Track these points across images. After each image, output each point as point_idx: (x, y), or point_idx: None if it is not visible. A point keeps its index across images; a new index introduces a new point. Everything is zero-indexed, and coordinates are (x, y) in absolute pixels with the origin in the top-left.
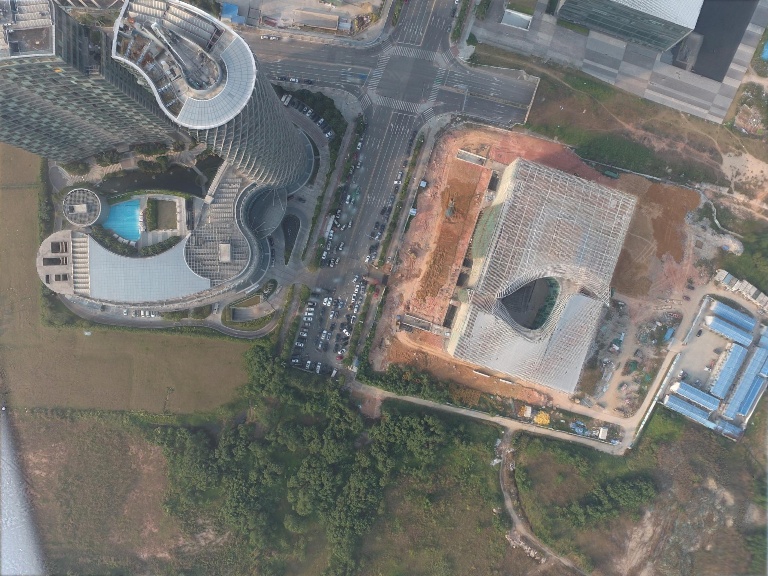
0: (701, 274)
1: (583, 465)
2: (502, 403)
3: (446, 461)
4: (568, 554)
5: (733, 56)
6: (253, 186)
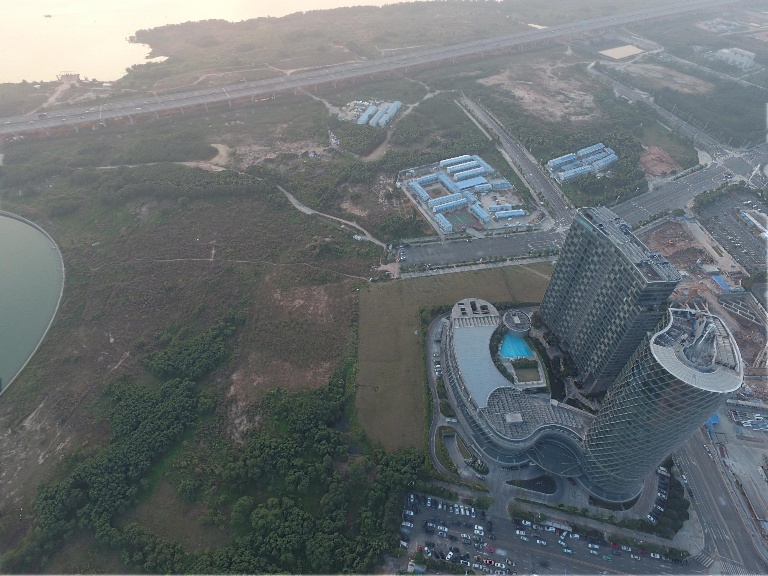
0: None
1: None
2: None
3: None
4: None
5: None
6: (579, 439)
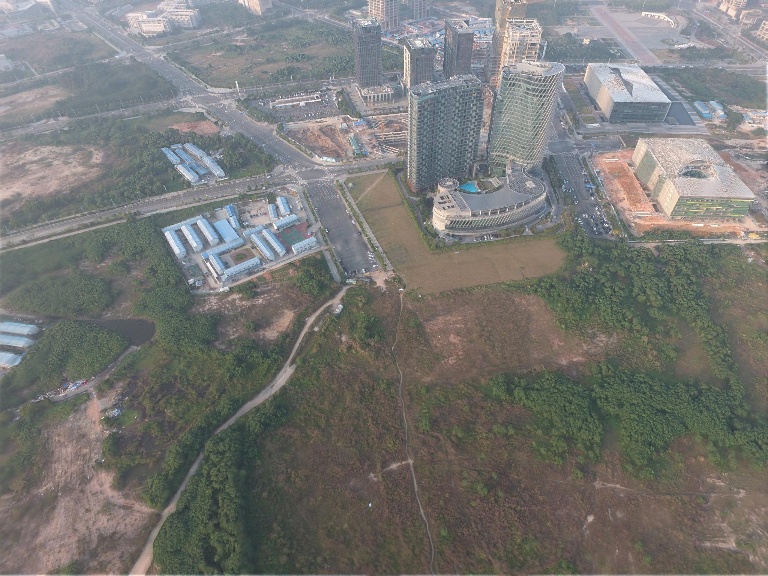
0: (763, 173)
1: None
2: None
3: (720, 265)
4: None
5: None
6: None
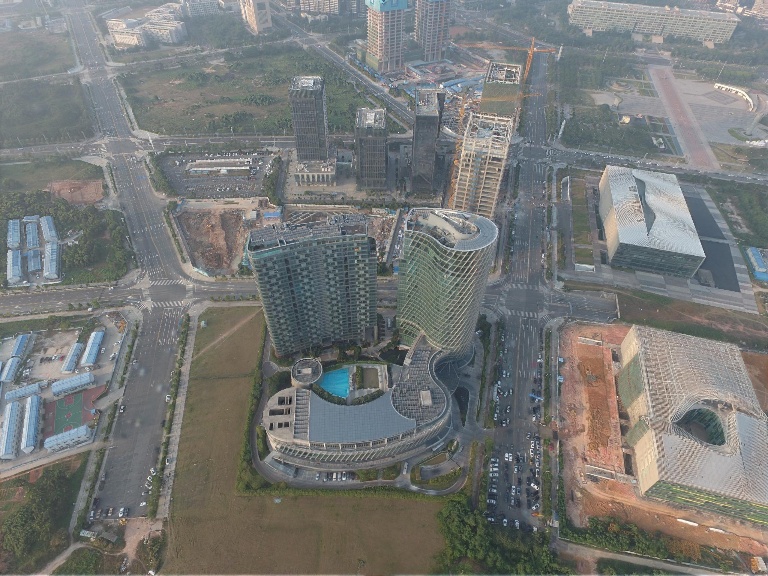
0: None
1: None
2: (727, 557)
3: None
4: None
5: (737, 279)
6: (440, 352)
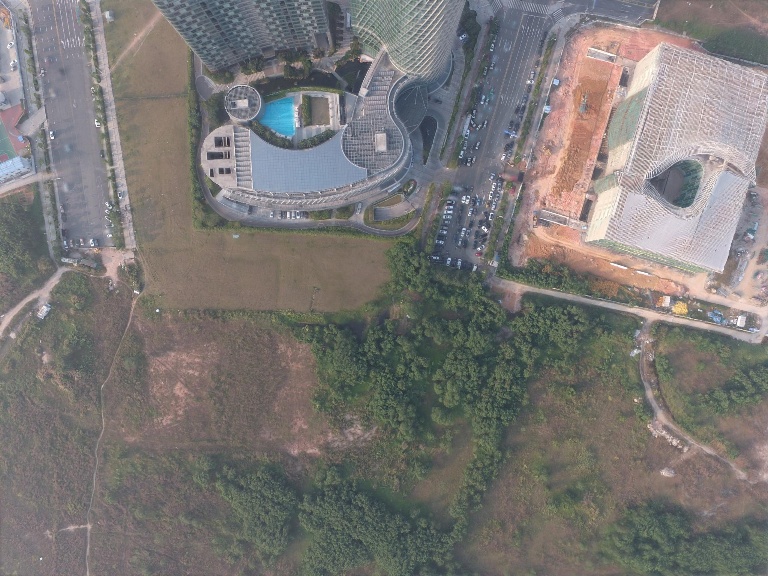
0: None
1: (725, 351)
2: (640, 294)
3: (587, 352)
4: (711, 441)
5: None
6: (404, 78)
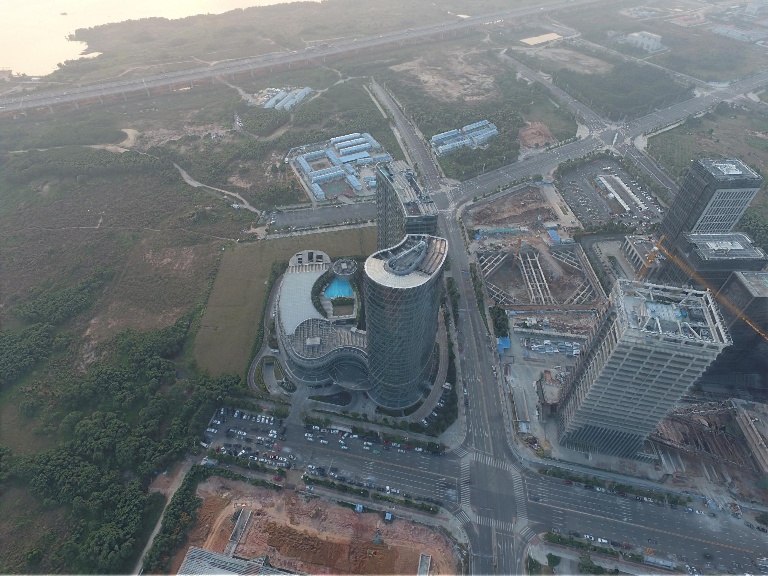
0: None
1: None
2: None
3: None
4: None
5: None
6: (366, 357)
